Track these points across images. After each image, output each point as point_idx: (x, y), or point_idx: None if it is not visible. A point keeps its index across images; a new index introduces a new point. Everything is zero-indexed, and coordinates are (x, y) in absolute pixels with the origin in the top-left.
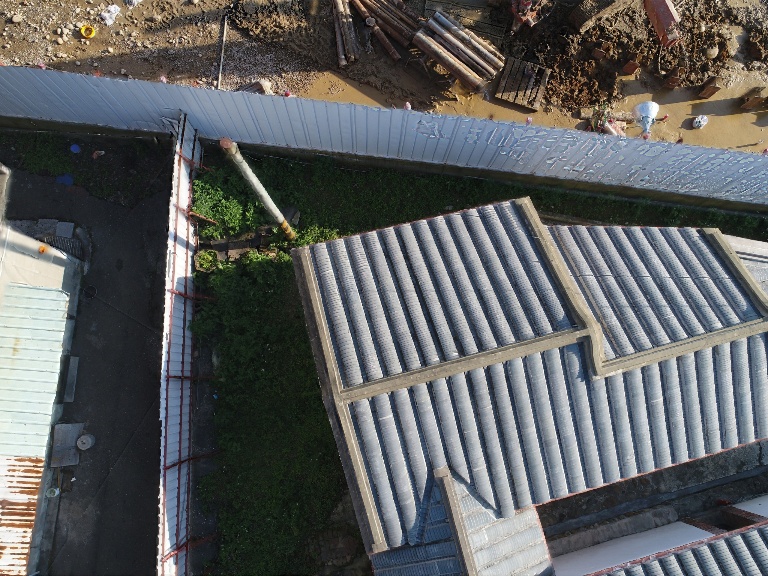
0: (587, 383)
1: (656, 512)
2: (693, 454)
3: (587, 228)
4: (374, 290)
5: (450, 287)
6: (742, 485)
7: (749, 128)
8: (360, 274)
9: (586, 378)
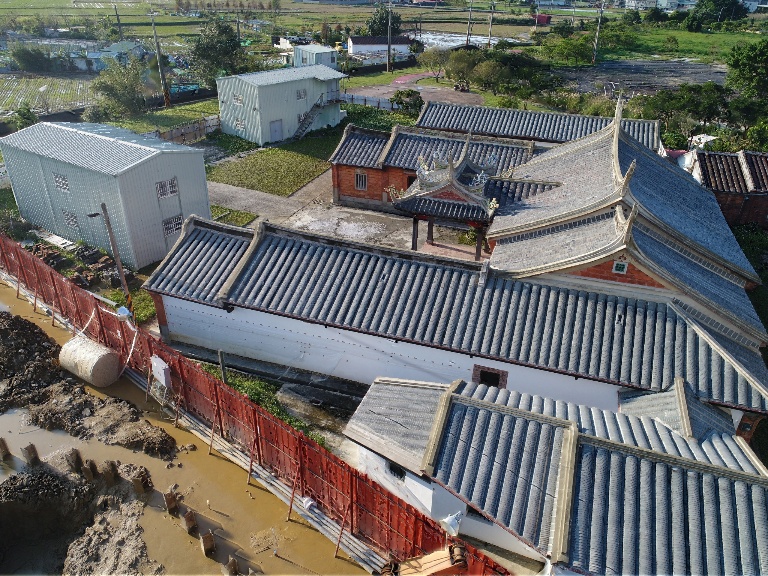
0: (580, 428)
1: None
2: (519, 393)
3: (508, 526)
4: (727, 551)
5: (659, 518)
6: None
7: (269, 570)
8: (737, 572)
9: (580, 429)
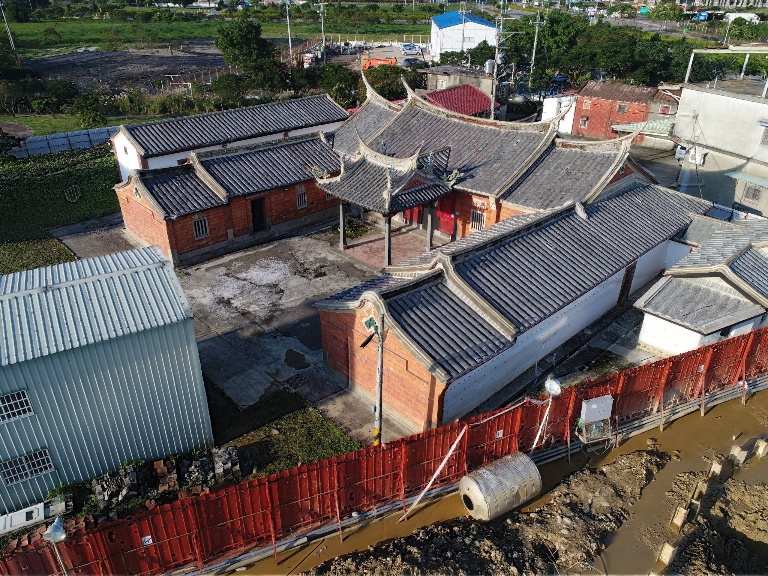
0: None
1: (637, 298)
2: None
3: None
4: None
5: None
6: (617, 314)
7: None
8: None
9: None
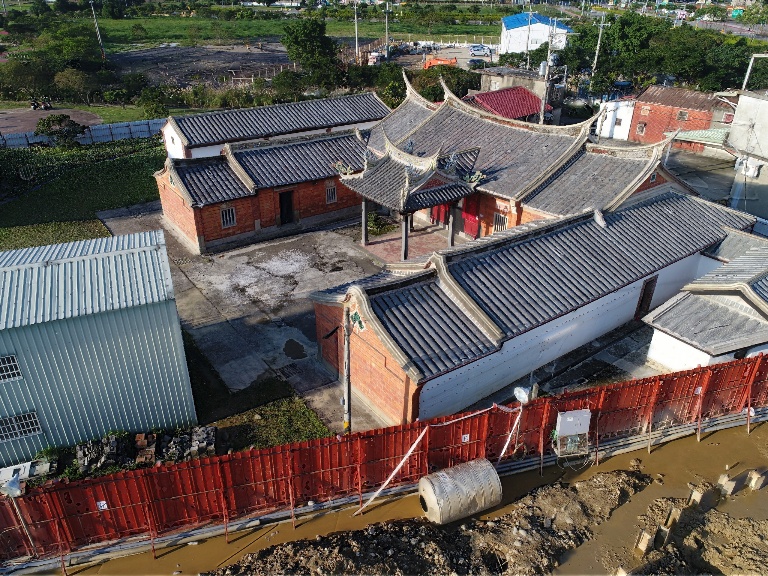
0: None
1: None
2: None
3: None
4: None
5: None
6: (632, 328)
7: None
8: None
9: None
